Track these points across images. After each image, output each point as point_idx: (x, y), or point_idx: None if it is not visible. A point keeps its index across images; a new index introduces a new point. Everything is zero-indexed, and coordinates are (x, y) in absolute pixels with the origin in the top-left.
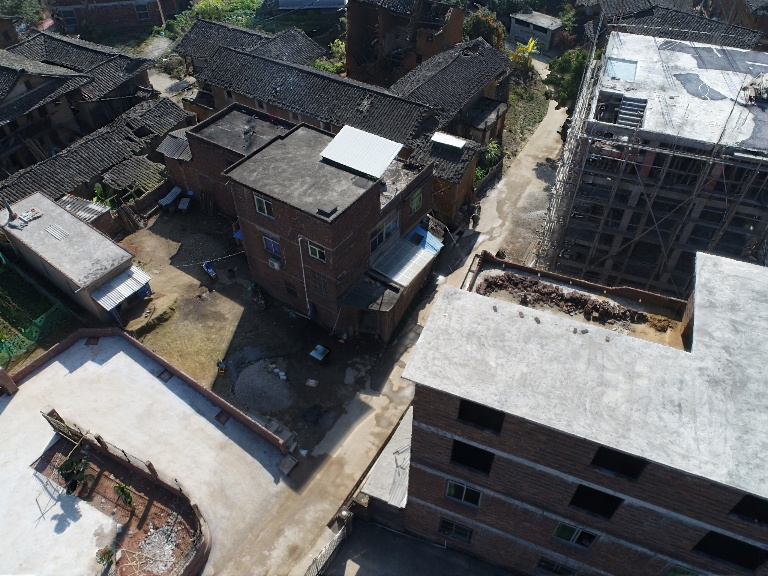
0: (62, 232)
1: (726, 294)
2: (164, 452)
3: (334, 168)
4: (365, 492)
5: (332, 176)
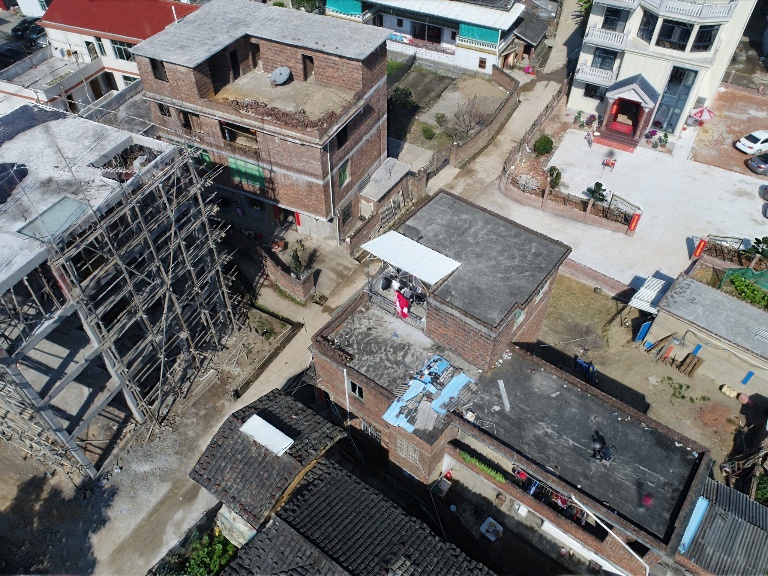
0: (767, 339)
1: (201, 48)
2: (549, 224)
3: (443, 253)
4: (410, 164)
5: (444, 242)
